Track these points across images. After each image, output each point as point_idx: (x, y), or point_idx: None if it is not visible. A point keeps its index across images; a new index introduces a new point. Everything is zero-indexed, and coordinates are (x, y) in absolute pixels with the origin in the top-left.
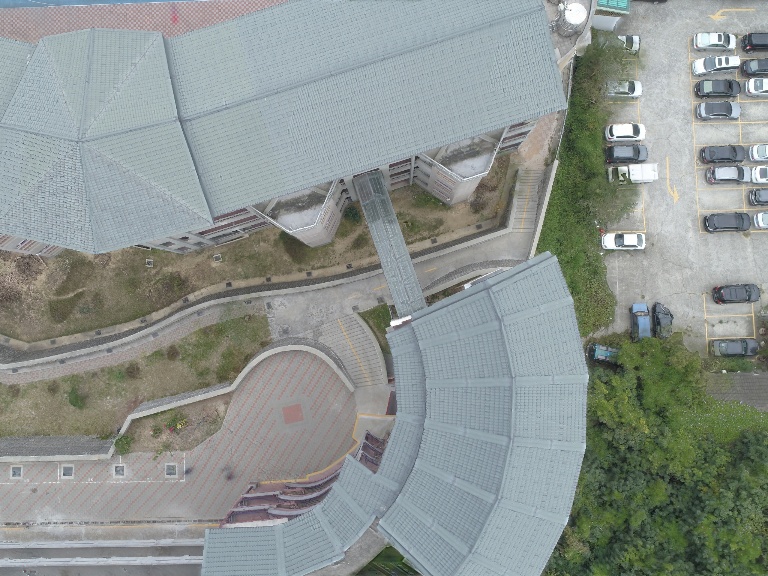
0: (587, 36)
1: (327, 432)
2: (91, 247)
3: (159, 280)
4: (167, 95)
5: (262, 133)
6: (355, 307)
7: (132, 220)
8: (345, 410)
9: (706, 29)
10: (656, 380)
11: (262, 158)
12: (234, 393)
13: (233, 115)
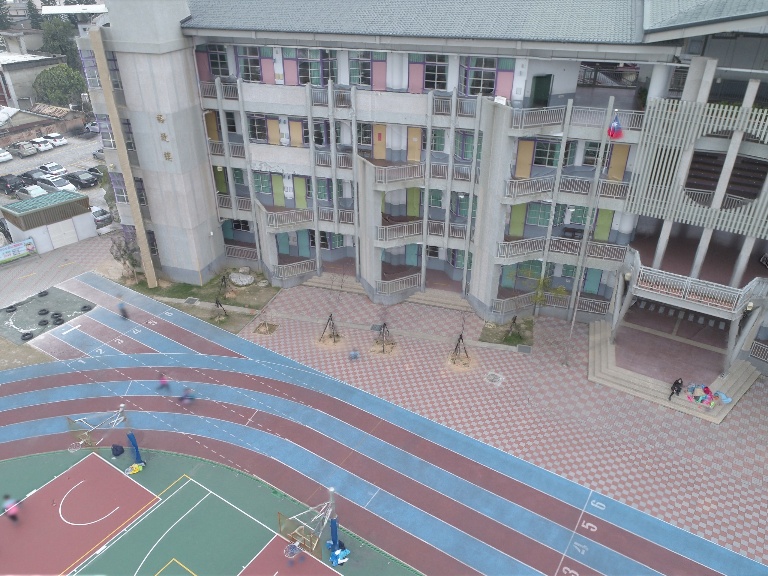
0: (105, 229)
1: None
2: None
3: None
4: None
5: None
6: None
7: None
8: None
9: None
10: None
11: None
12: None
13: None
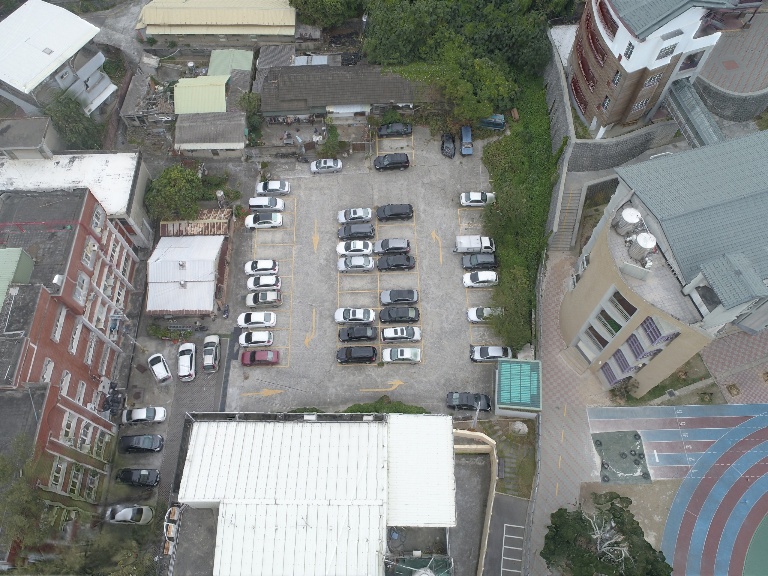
0: None
1: None
2: None
3: None
4: None
5: None
6: None
7: None
8: None
9: (407, 372)
10: (466, 94)
11: None
12: None
13: None
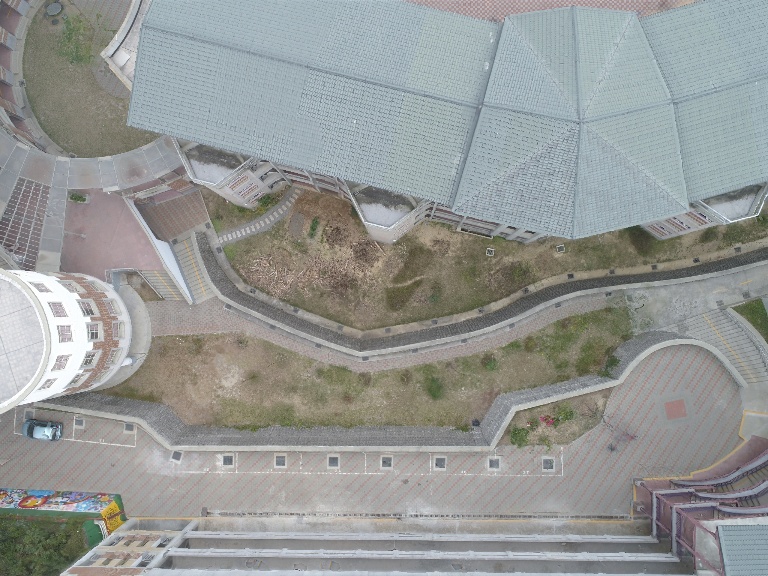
0: None
1: (711, 429)
2: (567, 232)
3: (499, 270)
4: (656, 77)
5: (747, 118)
6: (720, 302)
7: (613, 205)
8: (730, 407)
9: None
10: None
11: (743, 144)
12: (615, 387)
13: (721, 99)
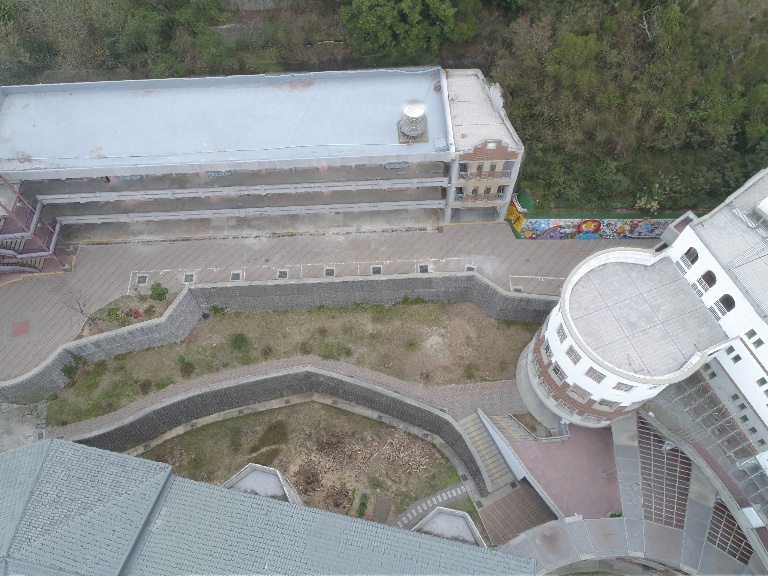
0: None
1: None
2: None
3: None
4: None
5: None
6: None
7: (1, 474)
8: None
9: None
10: None
11: None
12: None
13: None
